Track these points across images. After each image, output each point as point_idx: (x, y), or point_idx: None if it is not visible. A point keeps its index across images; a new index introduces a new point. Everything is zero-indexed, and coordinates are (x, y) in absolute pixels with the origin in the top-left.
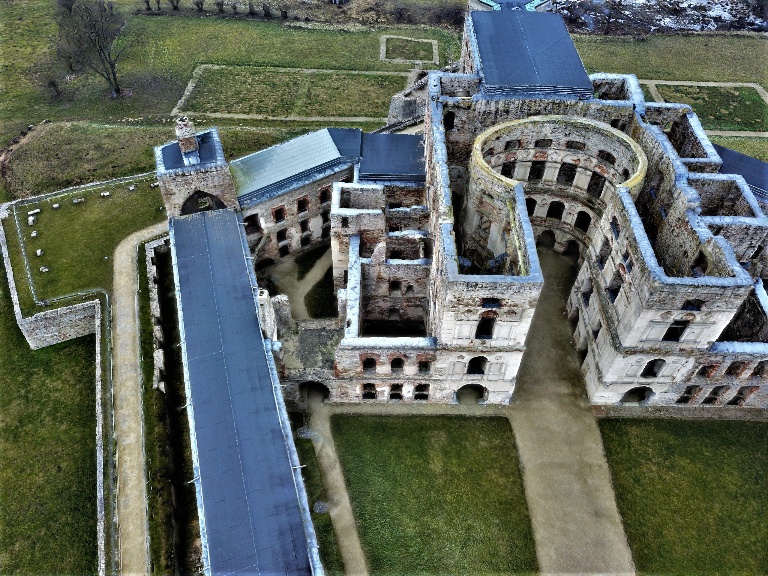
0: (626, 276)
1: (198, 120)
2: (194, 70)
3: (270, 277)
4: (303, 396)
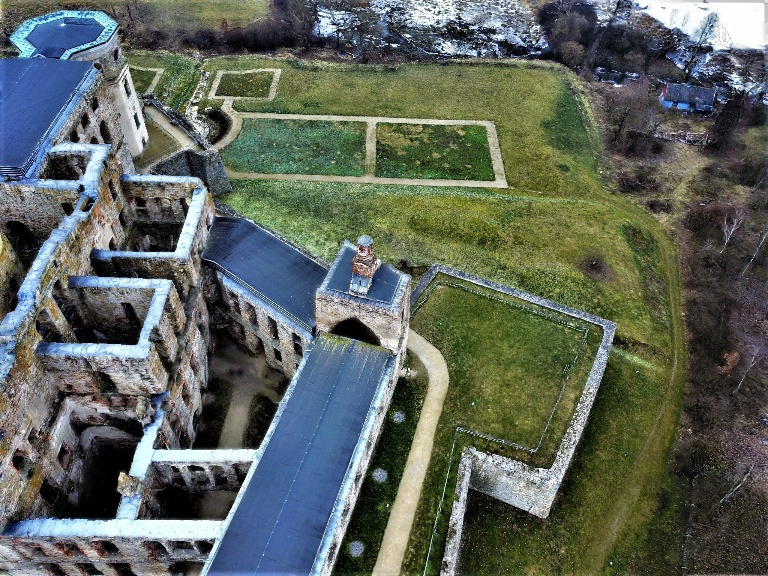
0: None
1: None
2: None
3: None
4: None
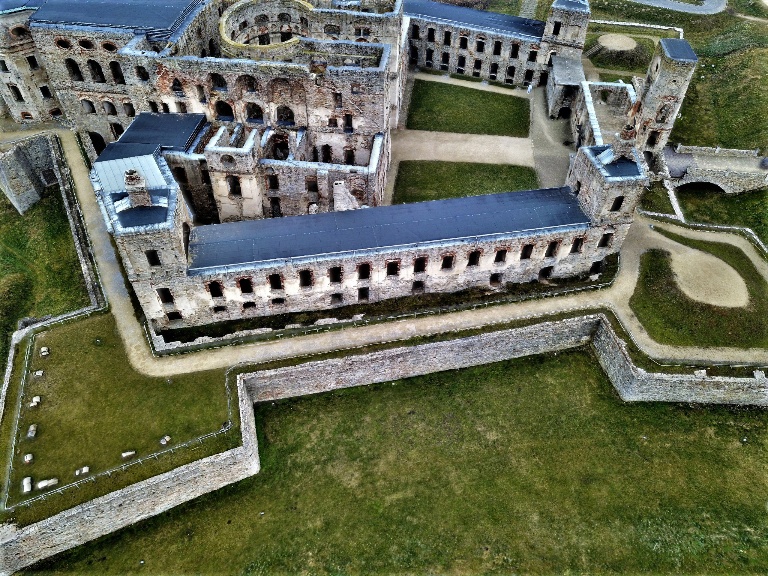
0: (368, 40)
1: None
2: None
3: None
4: None
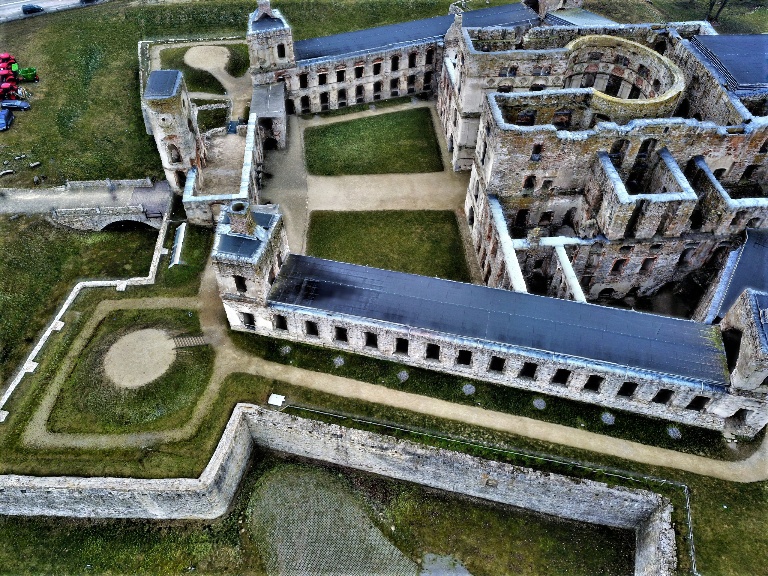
0: None
1: None
2: None
3: None
4: None
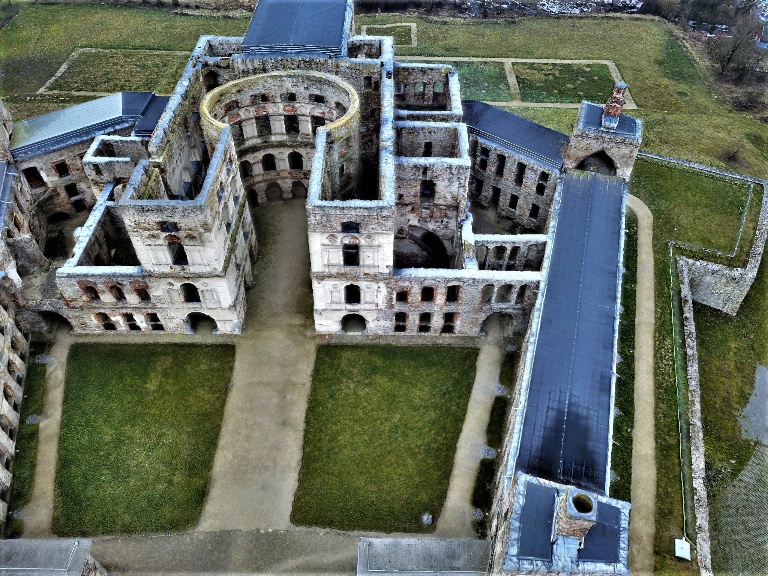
0: None
1: (61, 98)
2: (71, 53)
3: (62, 229)
4: (52, 328)
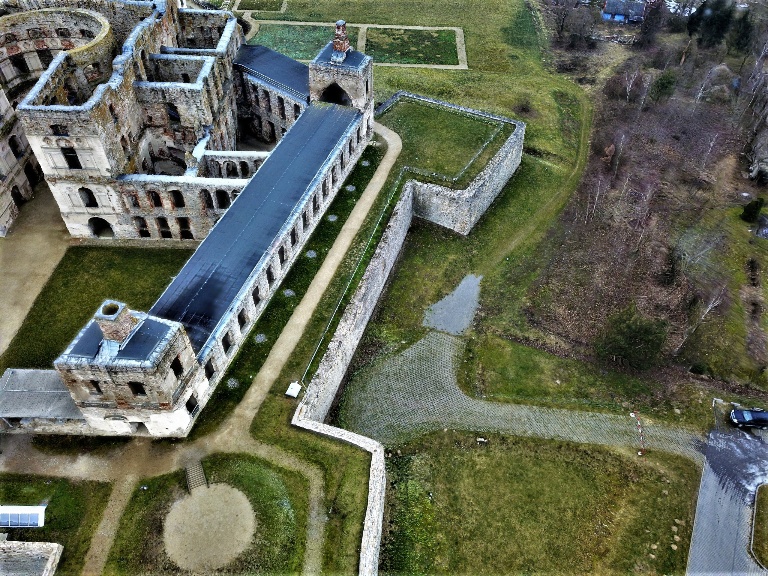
0: None
1: None
2: None
3: None
4: None
